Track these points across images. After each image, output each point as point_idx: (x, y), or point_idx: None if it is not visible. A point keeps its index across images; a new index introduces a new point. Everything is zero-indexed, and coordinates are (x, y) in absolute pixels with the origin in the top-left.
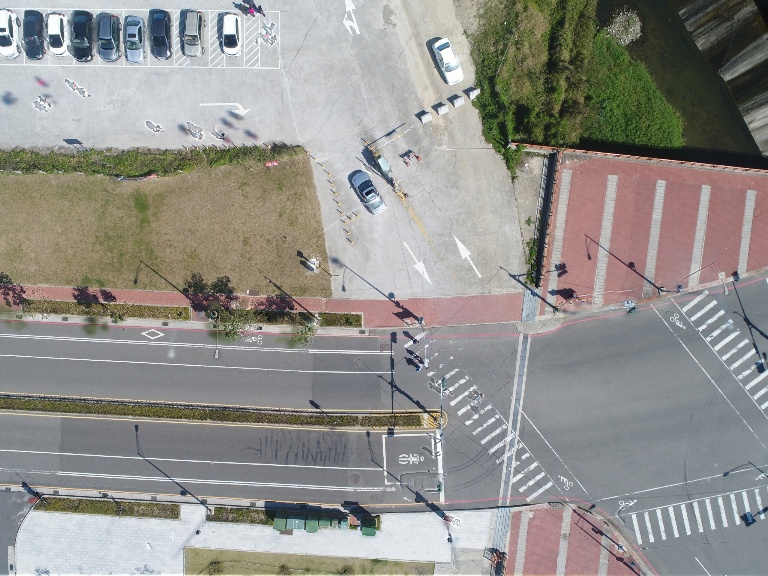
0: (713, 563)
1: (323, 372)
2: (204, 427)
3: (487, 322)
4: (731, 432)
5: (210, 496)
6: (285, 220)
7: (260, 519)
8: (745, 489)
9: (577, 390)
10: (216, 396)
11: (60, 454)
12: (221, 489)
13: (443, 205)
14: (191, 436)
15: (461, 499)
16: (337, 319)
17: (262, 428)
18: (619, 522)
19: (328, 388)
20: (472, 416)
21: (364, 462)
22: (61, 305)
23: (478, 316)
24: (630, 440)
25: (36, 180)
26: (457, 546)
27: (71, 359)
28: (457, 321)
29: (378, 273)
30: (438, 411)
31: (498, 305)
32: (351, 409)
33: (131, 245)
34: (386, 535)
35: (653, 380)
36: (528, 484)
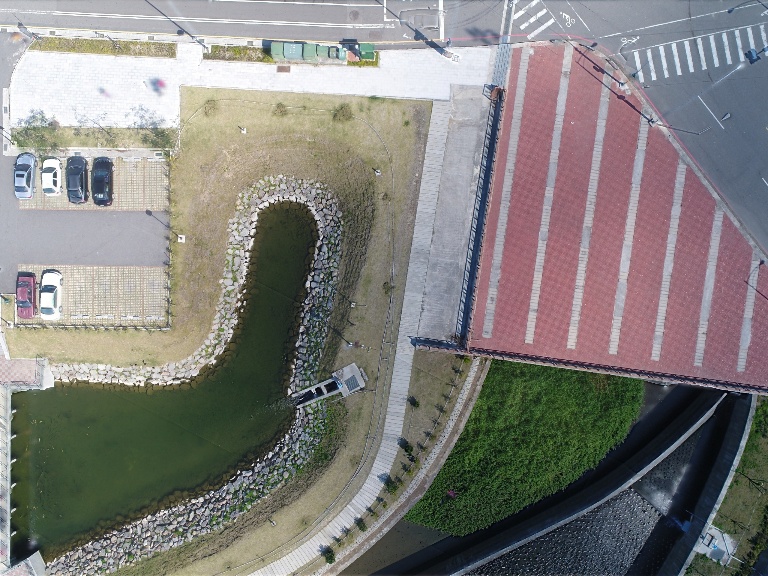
0: (716, 101)
1: None
2: None
3: None
4: None
5: (207, 35)
6: None
7: (257, 57)
8: (750, 25)
9: None
10: None
11: None
12: (218, 28)
13: None
14: None
15: (461, 36)
16: None
17: None
18: (621, 60)
19: None
20: None
21: None
22: None
23: None
24: None
25: None
26: (456, 83)
27: None
28: None
29: None
30: None
31: None
32: None
33: None
34: (384, 71)
35: None
36: (529, 21)
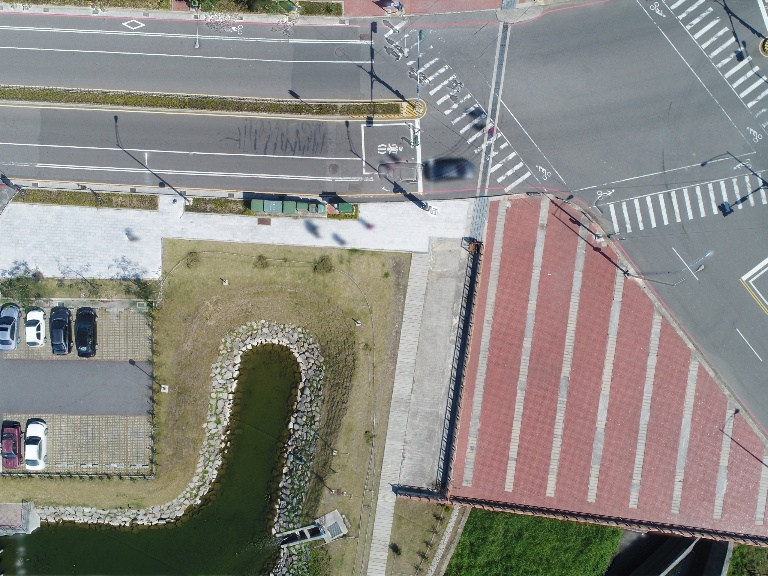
0: (690, 253)
1: (303, 62)
2: (183, 117)
3: (467, 10)
4: (710, 121)
5: (189, 187)
6: None
7: (238, 210)
8: (723, 178)
9: (556, 79)
10: (196, 86)
11: (39, 146)
12: (200, 180)
13: None
14: (170, 126)
15: (439, 189)
16: (317, 7)
17: (241, 118)
18: (597, 212)
19: (308, 78)
20: (451, 105)
21: (343, 152)
22: None
23: (458, 4)
24: (609, 129)
25: None
26: (434, 235)
27: (52, 50)
28: (437, 9)
29: None
30: (417, 100)
31: None
32: (330, 99)
33: None
34: (364, 224)
35: (632, 68)
36: (506, 174)
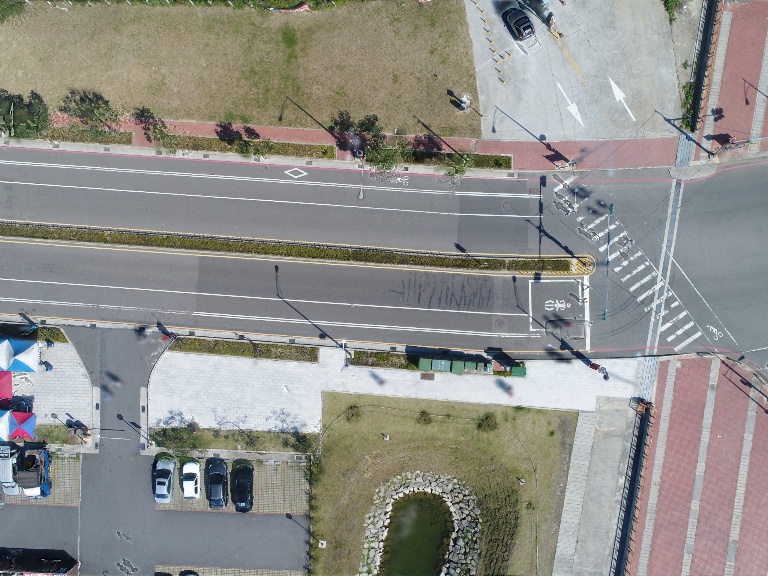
0: None
1: (470, 215)
2: (346, 268)
3: (640, 166)
4: None
5: (350, 340)
6: (436, 58)
7: (401, 364)
8: None
9: (730, 238)
10: (359, 237)
11: (197, 294)
12: (361, 333)
13: (599, 46)
14: (332, 278)
15: (607, 347)
16: (486, 160)
17: (406, 271)
18: None
19: (474, 231)
20: (621, 263)
21: (509, 307)
22: (203, 141)
23: (631, 160)
24: None
25: (182, 12)
26: (602, 395)
27: (211, 197)
28: (609, 165)
29: (530, 114)
30: (587, 257)
31: (652, 149)
32: (497, 253)
33: (277, 81)
34: (530, 382)
35: None
36: (676, 333)
